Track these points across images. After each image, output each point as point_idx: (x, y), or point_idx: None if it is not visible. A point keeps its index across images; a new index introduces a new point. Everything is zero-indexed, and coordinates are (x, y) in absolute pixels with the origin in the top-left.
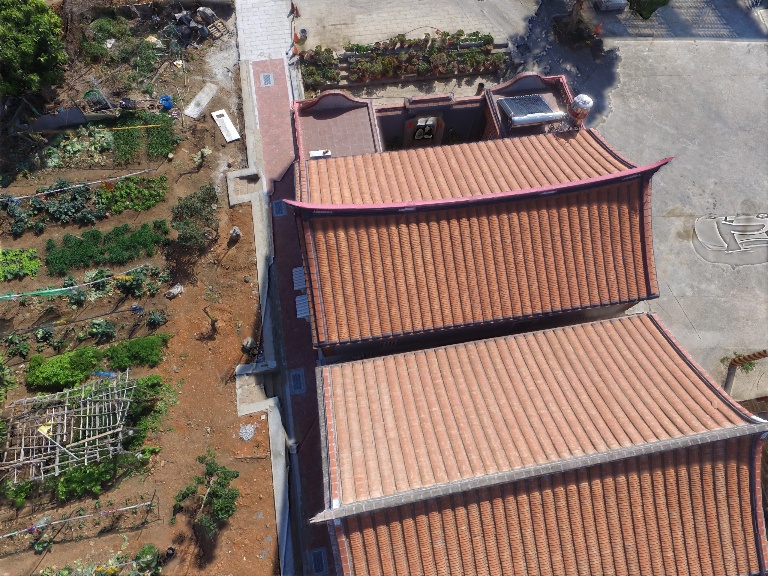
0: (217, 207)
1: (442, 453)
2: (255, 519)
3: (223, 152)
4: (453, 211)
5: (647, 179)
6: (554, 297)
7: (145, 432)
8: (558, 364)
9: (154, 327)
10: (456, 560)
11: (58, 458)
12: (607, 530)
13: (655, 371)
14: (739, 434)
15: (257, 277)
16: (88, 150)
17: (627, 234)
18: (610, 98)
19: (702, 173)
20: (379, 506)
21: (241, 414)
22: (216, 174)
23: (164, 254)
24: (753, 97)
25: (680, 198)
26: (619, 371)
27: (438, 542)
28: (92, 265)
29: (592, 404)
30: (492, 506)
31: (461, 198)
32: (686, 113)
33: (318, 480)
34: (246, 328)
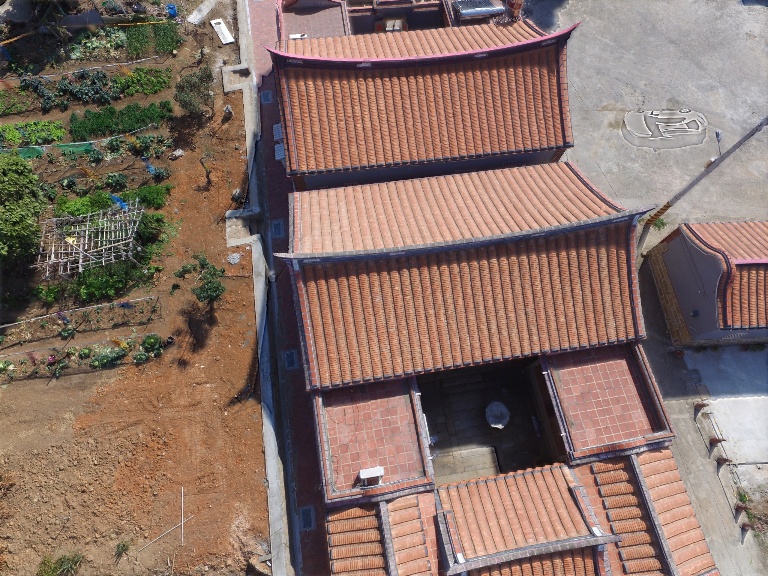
0: (213, 94)
1: (383, 239)
2: (239, 319)
3: (219, 52)
4: (402, 70)
5: (561, 45)
6: (485, 143)
7: (151, 255)
8: (485, 192)
9: (159, 180)
10: (391, 313)
11: (81, 260)
12: (512, 299)
13: (562, 194)
14: (613, 217)
15: (246, 146)
16: (105, 47)
17: (546, 93)
18: (559, 16)
19: (635, 77)
20: (328, 255)
21: (229, 246)
22: (213, 69)
23: (168, 127)
24: (686, 17)
25: (614, 96)
26: (534, 195)
27: (376, 297)
28: (108, 134)
29: (508, 213)
30: (420, 273)
31: (408, 57)
32: (625, 29)
33: (292, 301)
34: (235, 183)
